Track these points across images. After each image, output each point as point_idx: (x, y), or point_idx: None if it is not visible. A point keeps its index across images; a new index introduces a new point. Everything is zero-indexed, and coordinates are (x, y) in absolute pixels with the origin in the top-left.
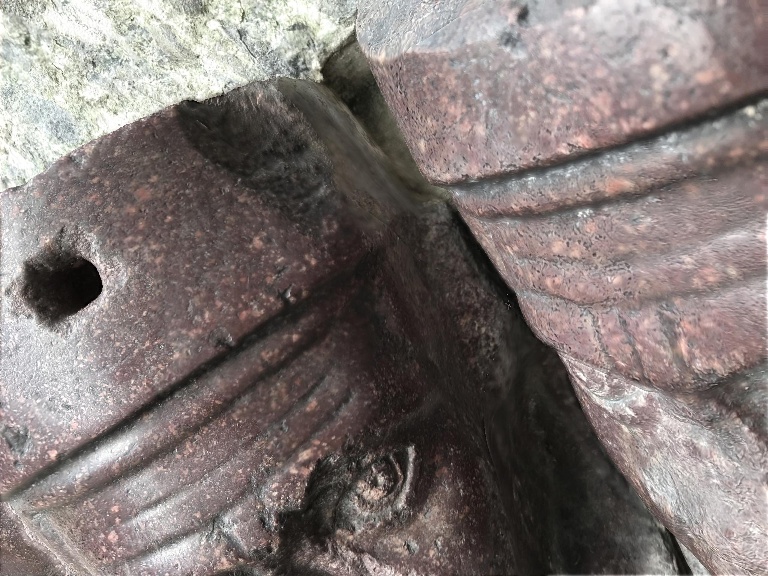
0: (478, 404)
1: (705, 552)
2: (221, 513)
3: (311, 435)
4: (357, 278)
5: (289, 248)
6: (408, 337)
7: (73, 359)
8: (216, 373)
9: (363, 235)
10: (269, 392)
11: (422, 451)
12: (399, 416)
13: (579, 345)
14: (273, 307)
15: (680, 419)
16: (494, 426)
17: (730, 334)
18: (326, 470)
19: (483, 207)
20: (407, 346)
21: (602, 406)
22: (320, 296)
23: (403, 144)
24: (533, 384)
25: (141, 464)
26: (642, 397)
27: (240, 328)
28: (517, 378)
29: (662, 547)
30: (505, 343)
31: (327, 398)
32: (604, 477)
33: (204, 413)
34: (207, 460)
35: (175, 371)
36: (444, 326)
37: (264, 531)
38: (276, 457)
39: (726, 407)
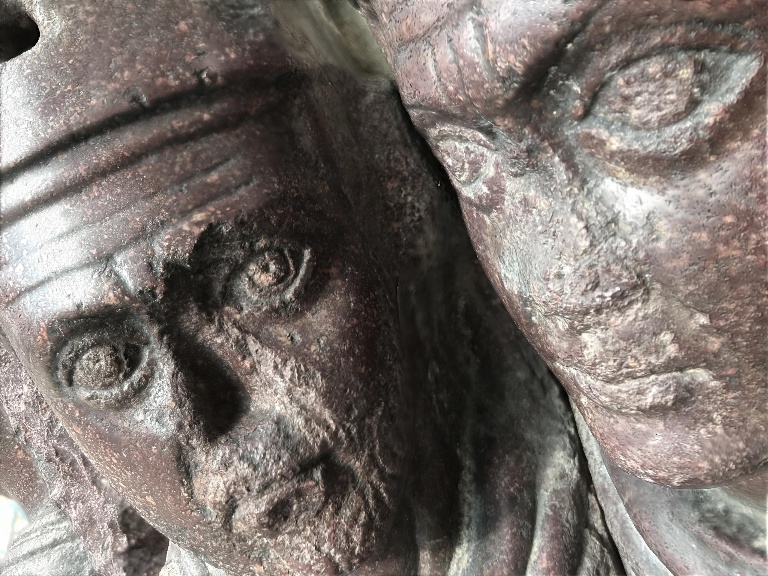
0: (394, 263)
1: (543, 329)
2: (115, 254)
3: (208, 202)
4: (277, 90)
5: (212, 38)
6: (322, 160)
7: (3, 93)
8: (128, 129)
9: (289, 56)
10: (175, 158)
11: (318, 257)
12: (298, 215)
13: (424, 84)
14: (188, 81)
15: (514, 172)
16: (416, 303)
17: (517, 17)
18: (218, 238)
19: None
20: (319, 167)
21: (468, 195)
22: (237, 91)
23: (360, 29)
24: (464, 282)
25: (51, 200)
26: (491, 166)
27: (154, 91)
28: (446, 268)
29: (567, 445)
30: (431, 218)
31: (228, 176)
32: (523, 380)
33: (112, 161)
34: (109, 205)
35: (90, 115)
36: (367, 177)
37: (151, 274)
38: (172, 213)
39: (537, 132)
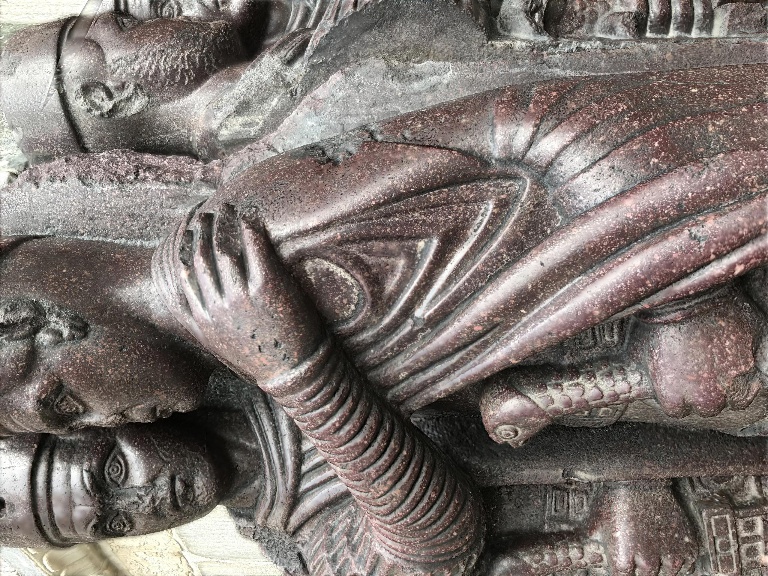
0: None
1: (207, 1)
2: None
3: None
4: None
5: None
6: None
7: None
8: None
9: None
10: None
11: None
12: None
13: None
14: None
15: None
16: None
17: None
18: None
19: (122, 2)
20: None
21: (176, 15)
22: None
23: None
24: None
25: None
26: None
27: None
28: None
29: None
30: None
31: None
32: None
33: None
34: None
35: None
36: None
37: None
38: None
39: None
